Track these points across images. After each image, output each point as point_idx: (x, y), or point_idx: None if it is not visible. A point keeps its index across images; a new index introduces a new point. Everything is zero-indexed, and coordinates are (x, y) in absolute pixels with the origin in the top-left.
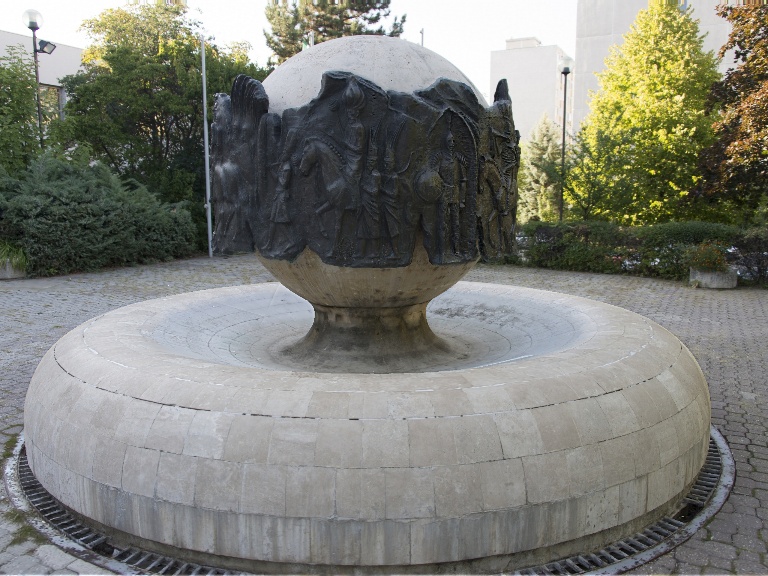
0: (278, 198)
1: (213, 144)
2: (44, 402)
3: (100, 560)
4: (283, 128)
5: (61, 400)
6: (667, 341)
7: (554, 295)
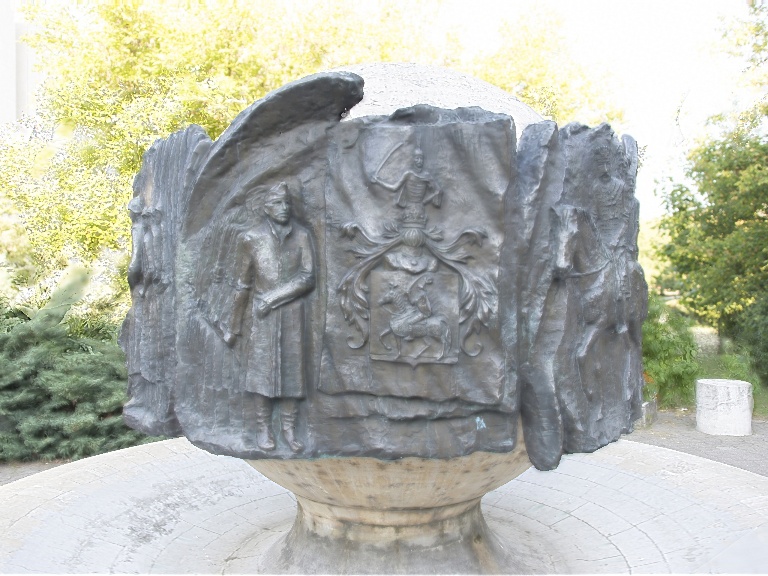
0: None
1: (628, 221)
2: None
3: None
4: None
5: None
6: None
7: (148, 450)
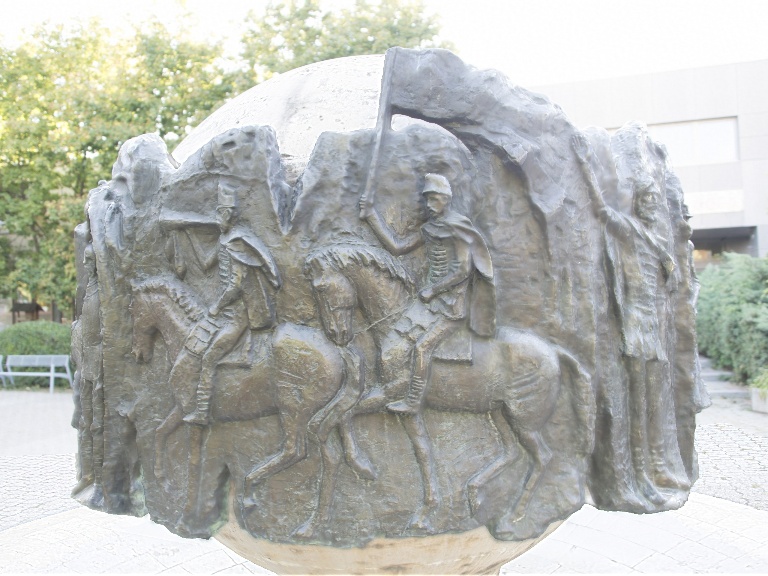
0: None
1: None
2: None
3: None
4: None
5: None
6: None
7: None
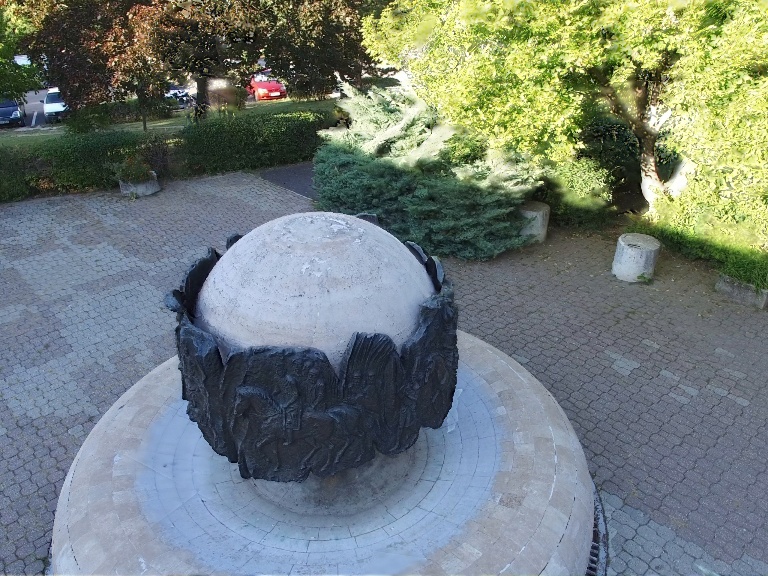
0: (408, 410)
1: None
2: None
3: None
4: (410, 360)
5: None
6: None
7: None
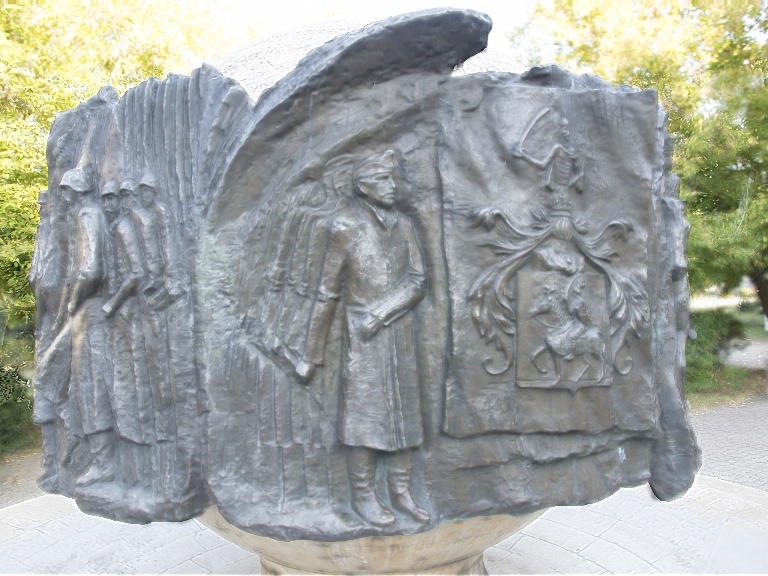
0: None
1: None
2: None
3: None
4: None
5: None
6: None
7: None
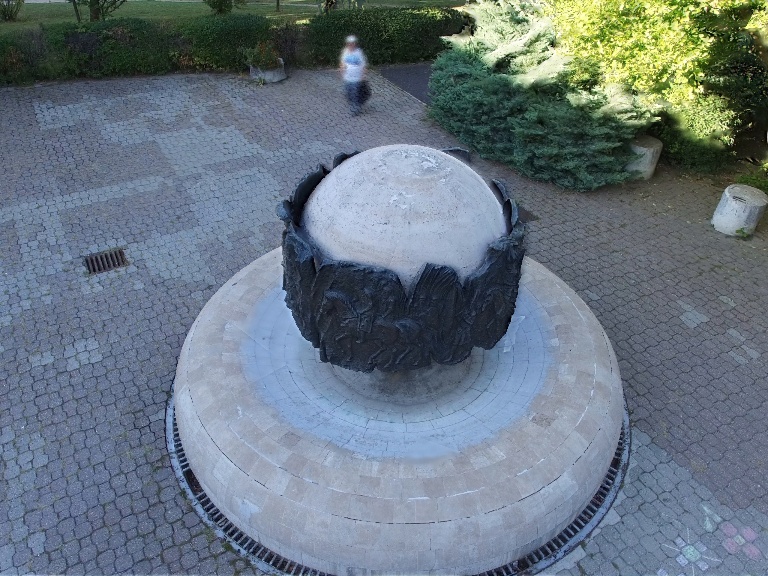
0: (463, 331)
1: None
2: (437, 548)
3: (533, 571)
4: (470, 291)
5: (461, 537)
6: (547, 271)
7: None
